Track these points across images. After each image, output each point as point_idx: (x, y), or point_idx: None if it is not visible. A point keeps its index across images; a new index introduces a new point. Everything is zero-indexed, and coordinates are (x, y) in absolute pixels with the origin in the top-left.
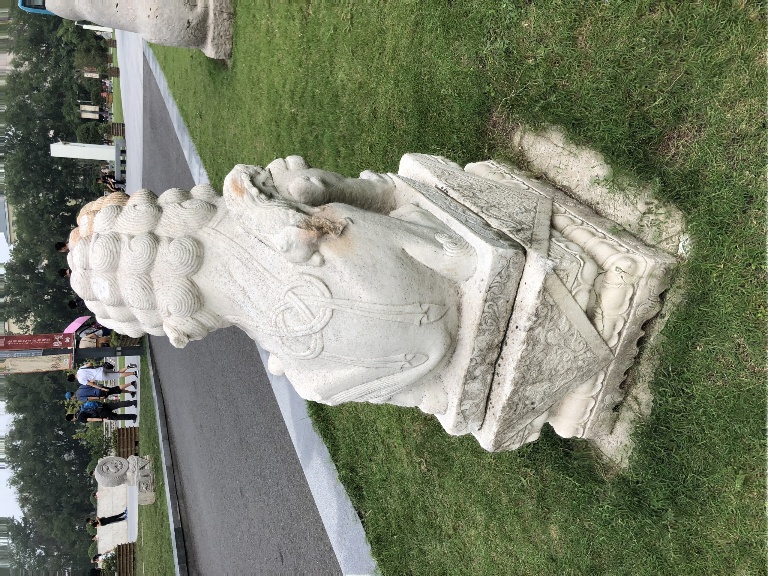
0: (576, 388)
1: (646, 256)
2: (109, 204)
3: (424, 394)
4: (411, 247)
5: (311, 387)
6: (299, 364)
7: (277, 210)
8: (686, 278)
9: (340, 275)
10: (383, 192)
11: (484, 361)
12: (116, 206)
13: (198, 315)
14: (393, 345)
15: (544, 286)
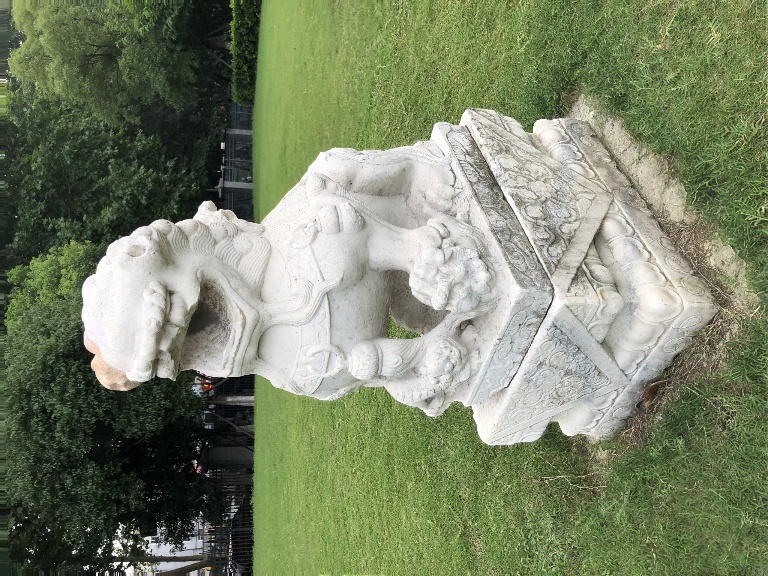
0: None
1: None
2: None
3: None
4: None
5: None
6: None
7: None
8: None
9: None
10: None
11: None
12: None
13: None
14: None
15: None
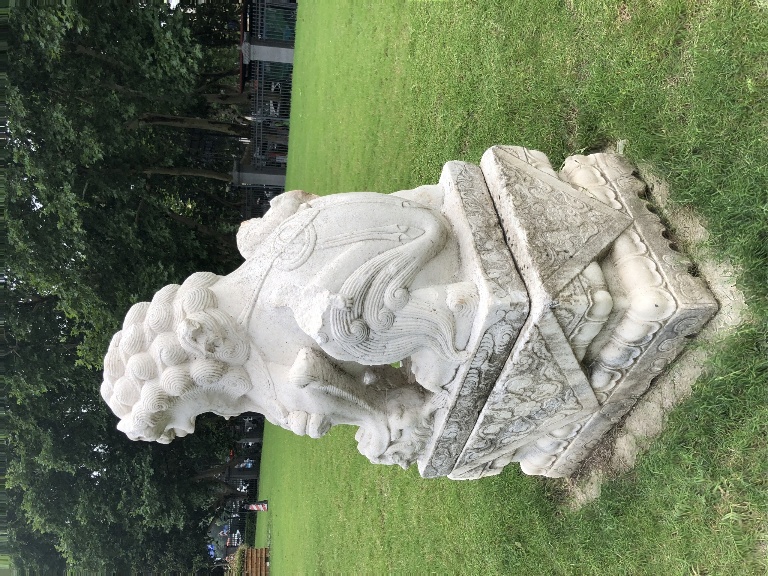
0: (617, 252)
1: None
2: None
3: (447, 288)
4: None
5: (315, 283)
6: (301, 276)
7: None
8: (622, 131)
9: (323, 202)
10: None
11: (490, 238)
12: None
13: (211, 311)
14: (381, 216)
15: (497, 156)
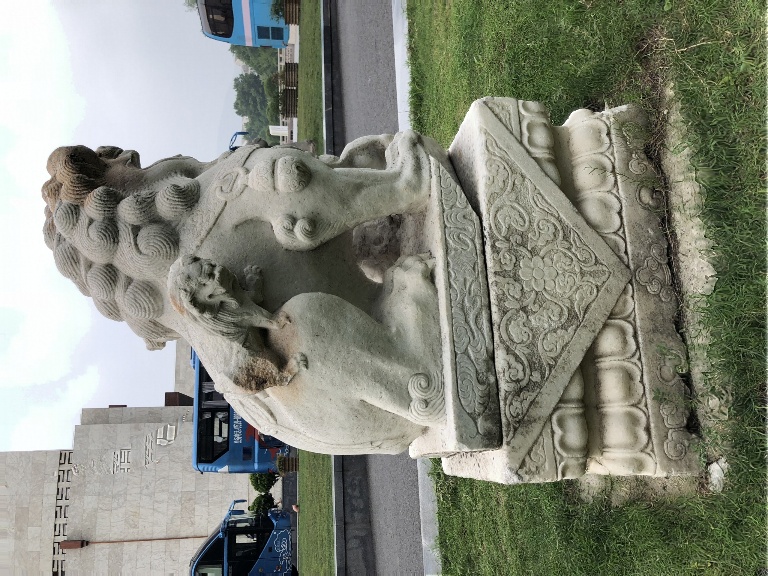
0: None
1: (661, 464)
2: (66, 200)
3: None
4: (371, 401)
5: None
6: None
7: (220, 340)
8: None
9: None
10: (410, 204)
11: None
12: (72, 211)
13: None
14: None
15: None
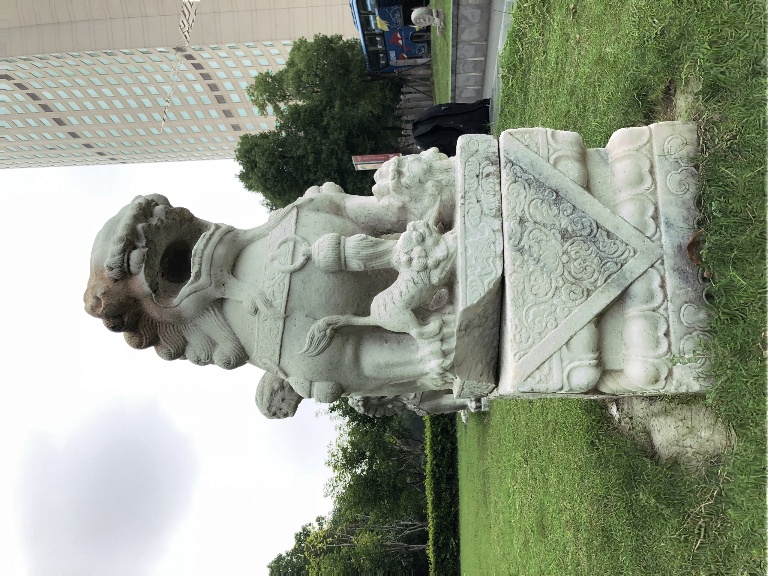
0: None
1: None
2: None
3: None
4: None
5: None
6: None
7: None
8: None
9: None
10: None
11: None
12: None
13: None
14: None
15: None
